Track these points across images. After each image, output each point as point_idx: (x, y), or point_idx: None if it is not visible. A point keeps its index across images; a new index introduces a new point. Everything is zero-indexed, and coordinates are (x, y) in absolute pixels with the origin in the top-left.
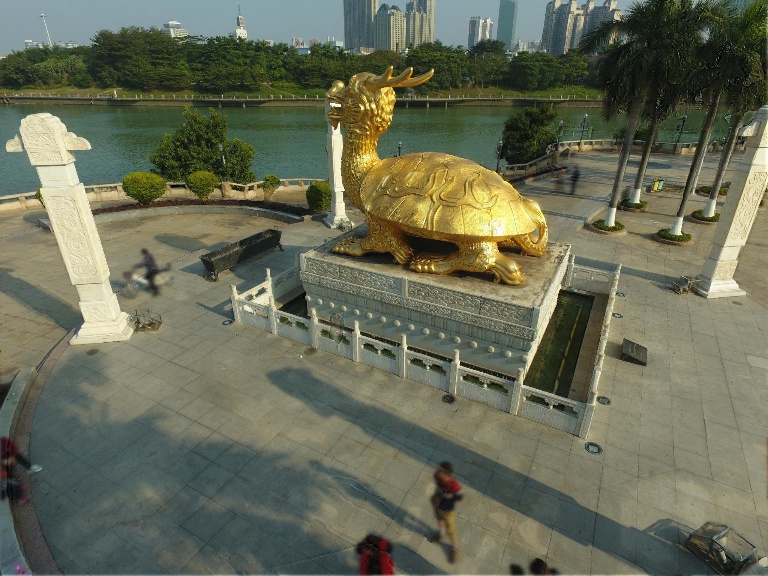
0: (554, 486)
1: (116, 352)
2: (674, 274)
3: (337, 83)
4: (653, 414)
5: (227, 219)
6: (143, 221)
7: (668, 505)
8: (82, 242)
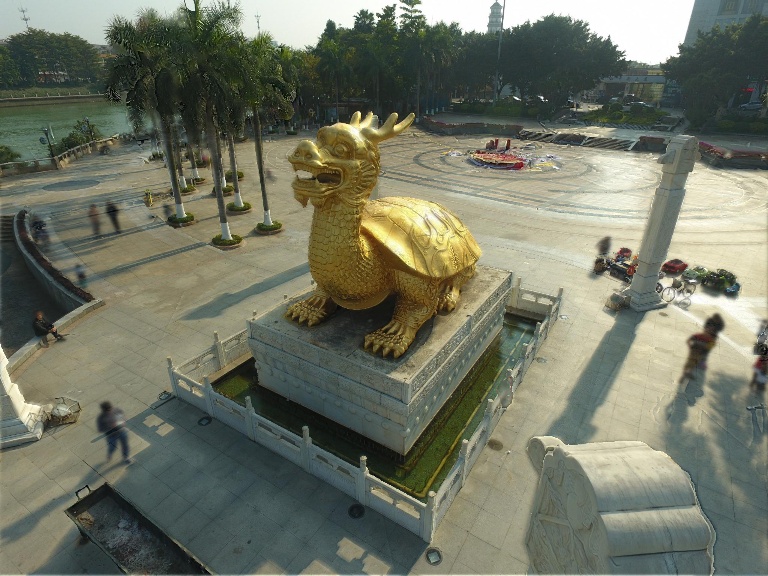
0: (602, 335)
1: None
2: None
3: None
4: None
5: None
6: None
7: (594, 308)
8: None
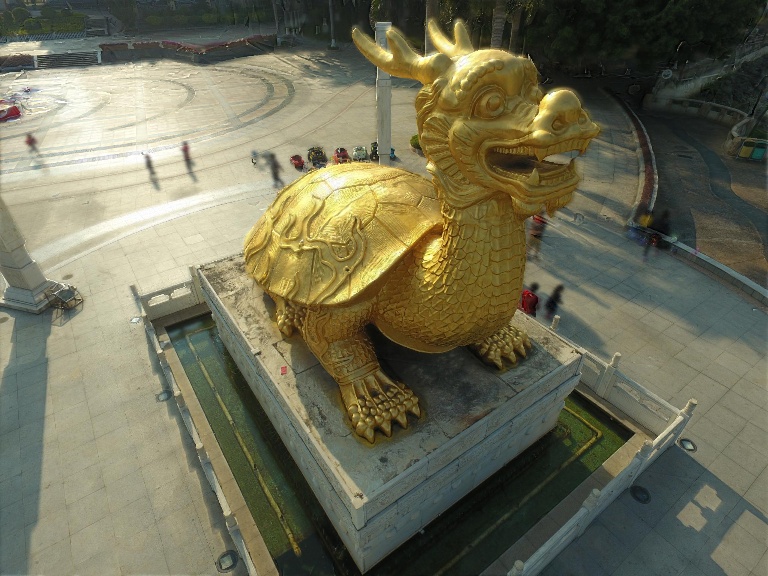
0: None
1: None
2: None
3: None
4: None
5: None
6: None
7: None
8: None
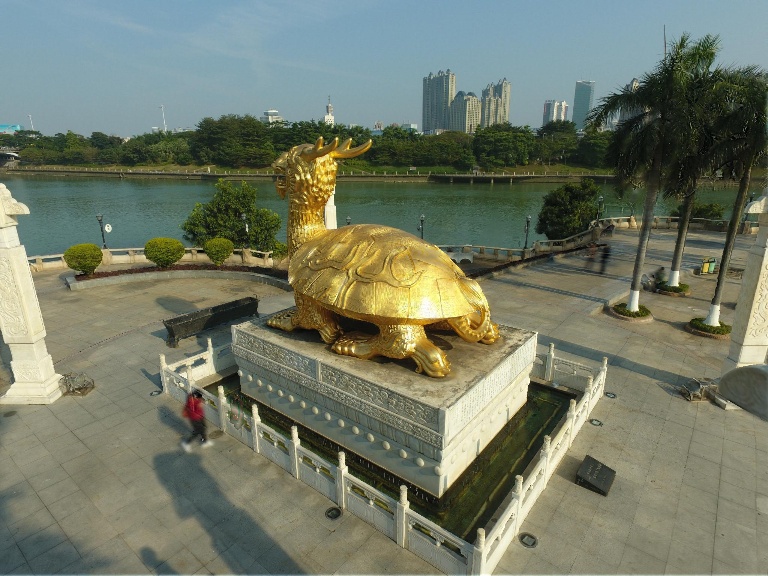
0: None
1: (31, 416)
2: (692, 374)
3: (284, 154)
4: (589, 570)
5: (233, 285)
6: (156, 283)
7: None
8: (15, 302)
